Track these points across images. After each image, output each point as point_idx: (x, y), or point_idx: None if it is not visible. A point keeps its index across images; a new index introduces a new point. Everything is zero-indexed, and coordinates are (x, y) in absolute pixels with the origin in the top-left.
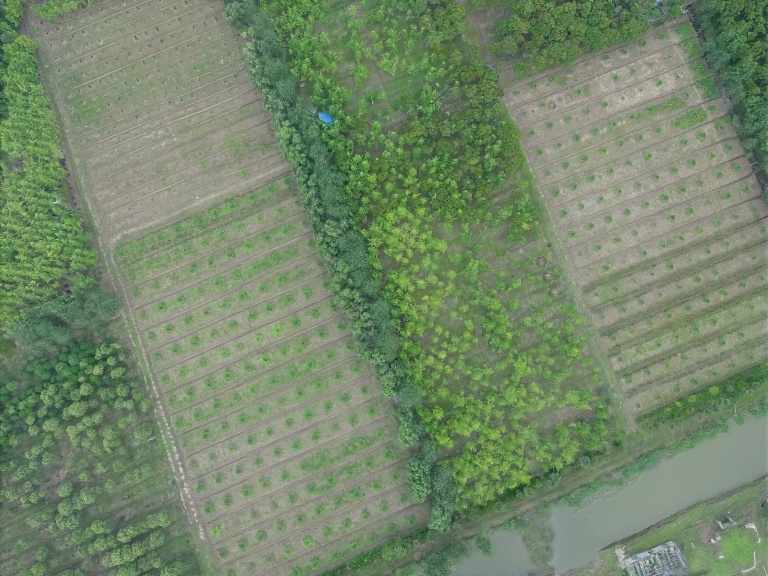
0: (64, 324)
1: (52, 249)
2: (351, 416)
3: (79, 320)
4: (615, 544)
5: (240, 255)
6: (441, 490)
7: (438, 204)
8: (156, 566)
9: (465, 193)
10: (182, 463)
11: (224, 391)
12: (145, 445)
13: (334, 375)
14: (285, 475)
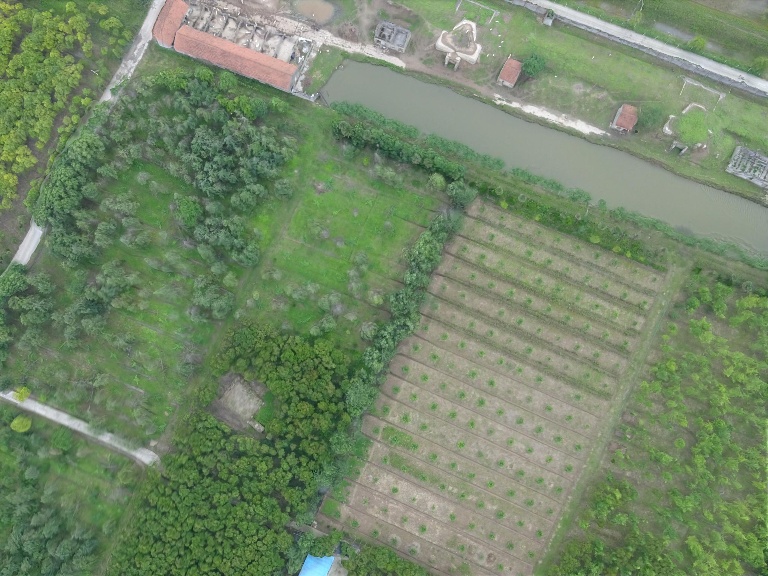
0: None
1: None
2: None
3: None
4: (766, 206)
5: None
6: None
7: None
8: None
9: None
10: None
11: None
12: None
13: None
14: None
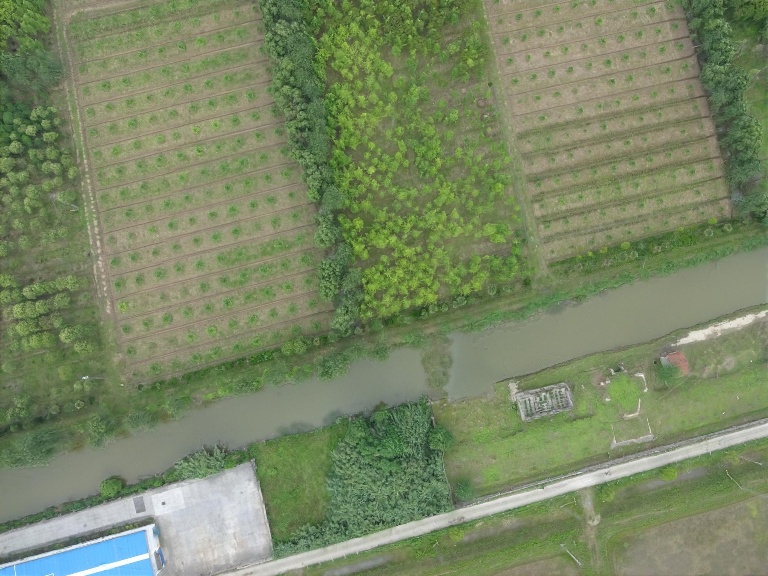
0: (4, 78)
1: (5, 7)
2: (274, 218)
3: (20, 77)
4: (510, 379)
5: (191, 50)
6: (348, 292)
7: (390, 27)
8: (57, 325)
9: (418, 21)
10: (100, 237)
11: (154, 176)
12: (67, 215)
13: (264, 176)
14: (200, 263)
